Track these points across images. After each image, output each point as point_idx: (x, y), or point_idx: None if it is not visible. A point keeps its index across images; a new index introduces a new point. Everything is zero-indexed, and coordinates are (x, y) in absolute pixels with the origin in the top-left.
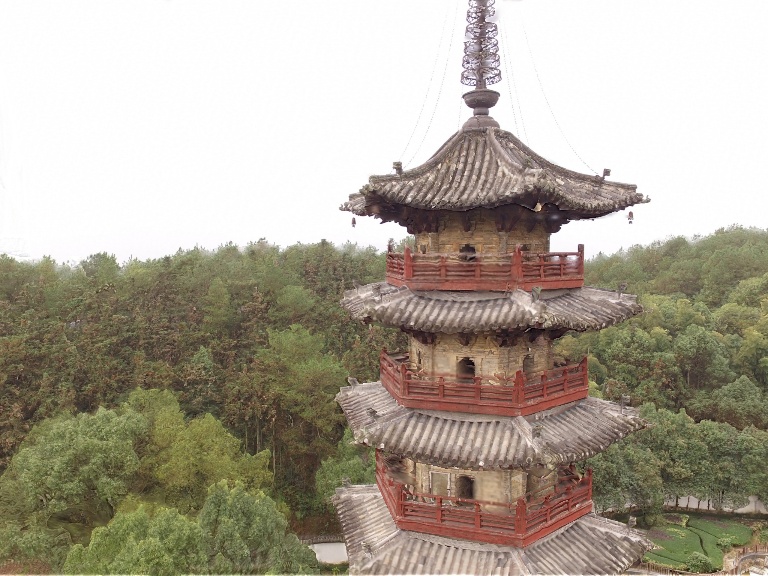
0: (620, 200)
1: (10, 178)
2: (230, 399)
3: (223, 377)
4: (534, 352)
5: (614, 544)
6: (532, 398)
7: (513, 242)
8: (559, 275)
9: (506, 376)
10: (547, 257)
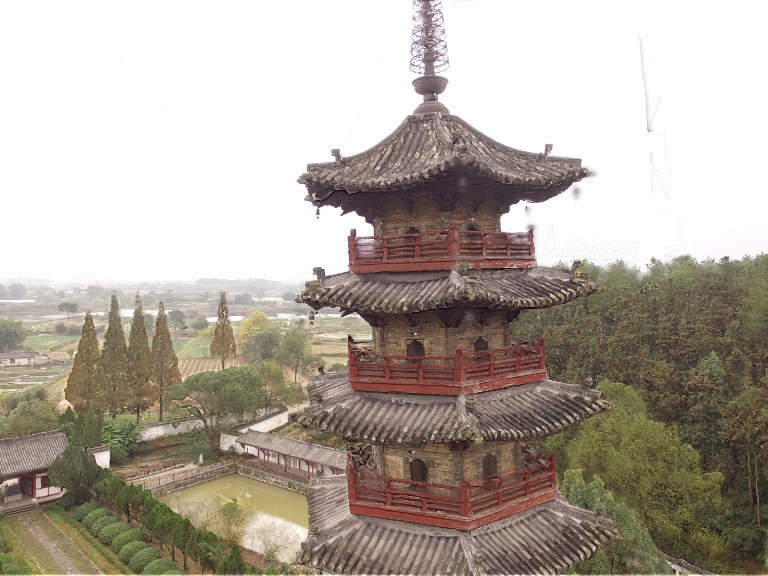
0: (432, 169)
1: (673, 190)
2: (726, 413)
3: (738, 389)
4: (423, 338)
5: (454, 570)
6: (369, 376)
7: (394, 226)
8: (412, 257)
9: (381, 355)
10: (396, 239)
